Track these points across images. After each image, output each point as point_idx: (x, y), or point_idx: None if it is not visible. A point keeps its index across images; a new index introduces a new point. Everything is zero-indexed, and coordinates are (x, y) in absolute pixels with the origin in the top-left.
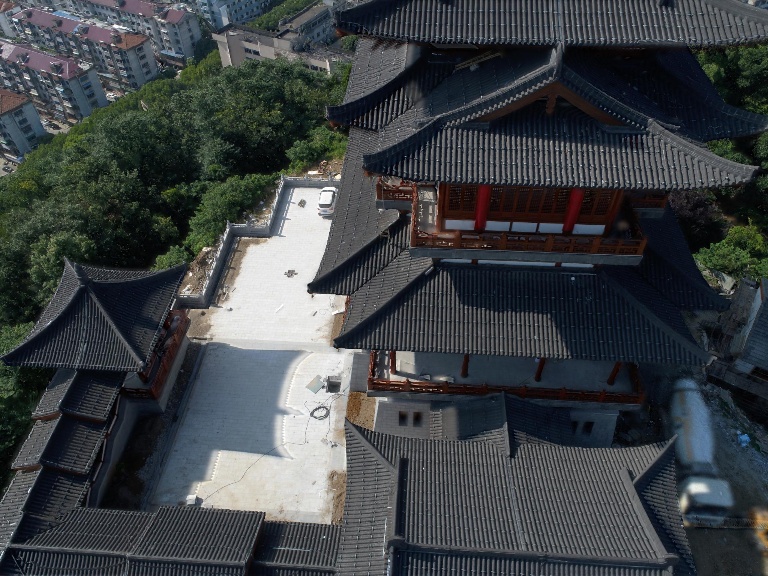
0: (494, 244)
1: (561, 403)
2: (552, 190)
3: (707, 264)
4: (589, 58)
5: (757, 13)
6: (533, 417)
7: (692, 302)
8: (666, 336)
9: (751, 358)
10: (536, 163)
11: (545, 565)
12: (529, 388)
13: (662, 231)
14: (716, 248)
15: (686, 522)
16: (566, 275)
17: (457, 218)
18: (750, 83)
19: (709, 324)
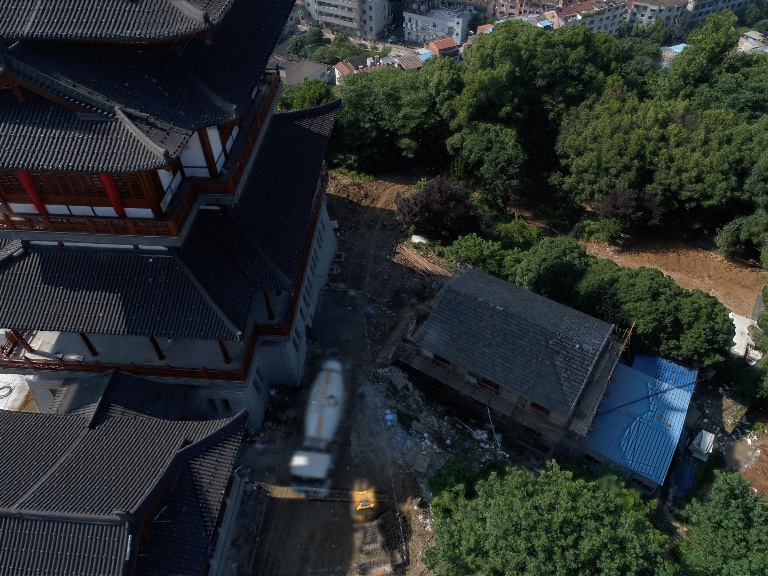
0: (44, 226)
1: (174, 380)
2: (84, 175)
3: (453, 256)
4: (75, 51)
5: (187, 9)
6: (141, 393)
7: (267, 283)
8: (215, 314)
9: (424, 342)
10: (8, 147)
11: (23, 522)
12: (137, 365)
13: (282, 218)
14: (464, 240)
15: (303, 495)
16: (145, 257)
17: (17, 202)
18: (548, 82)
19: (421, 312)
